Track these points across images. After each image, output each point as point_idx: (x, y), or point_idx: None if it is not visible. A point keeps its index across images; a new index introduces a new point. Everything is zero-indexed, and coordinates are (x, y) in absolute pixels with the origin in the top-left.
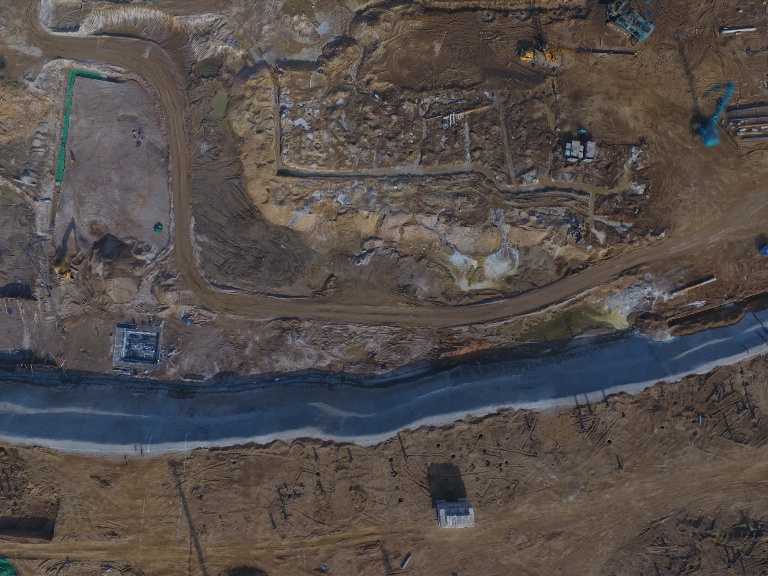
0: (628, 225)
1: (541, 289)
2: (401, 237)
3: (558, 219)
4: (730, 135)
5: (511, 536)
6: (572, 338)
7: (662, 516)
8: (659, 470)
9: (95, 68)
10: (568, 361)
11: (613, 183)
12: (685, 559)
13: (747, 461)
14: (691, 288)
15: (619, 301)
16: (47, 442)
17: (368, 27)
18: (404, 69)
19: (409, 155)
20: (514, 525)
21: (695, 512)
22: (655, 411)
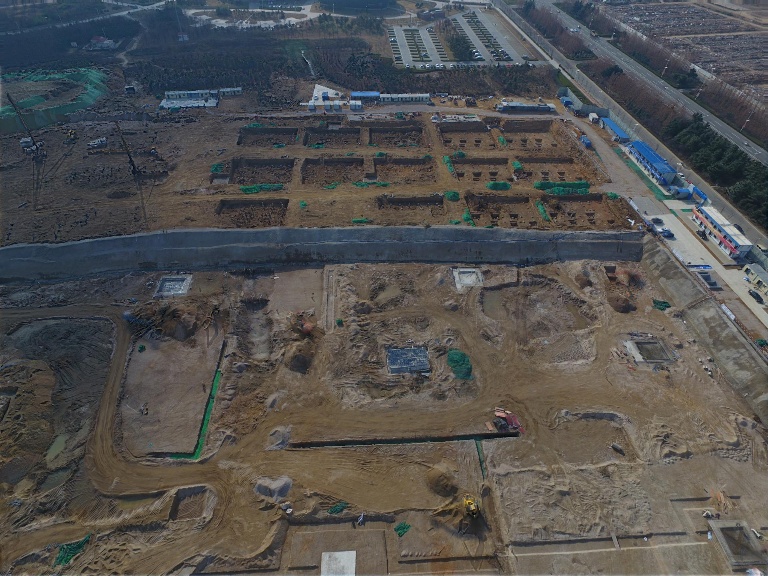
0: None
1: None
2: None
3: None
4: None
5: None
6: None
7: None
8: None
9: None
10: None
11: None
12: None
13: None
14: None
15: None
16: (218, 230)
17: None
18: None
19: None
20: None
21: None
22: None
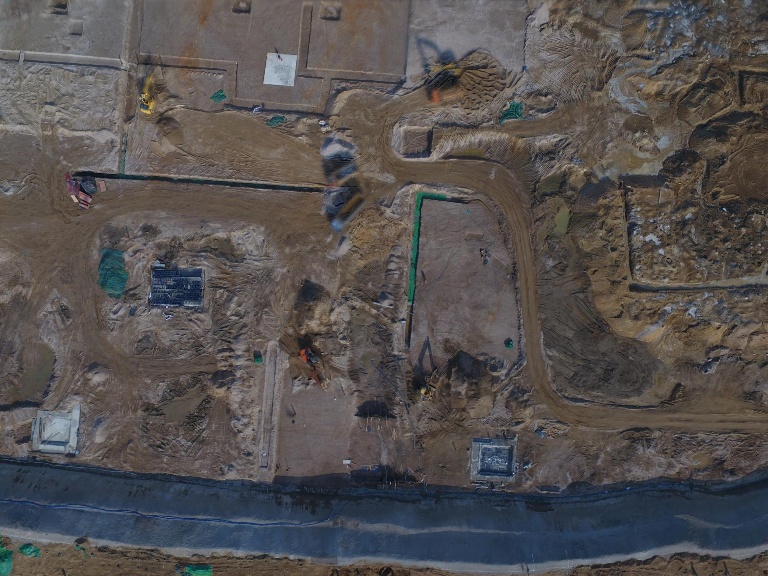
0: None
1: None
2: (747, 345)
3: None
4: None
5: None
6: None
7: None
8: None
9: (444, 191)
10: None
11: None
12: None
13: None
14: None
15: None
16: (439, 564)
17: (717, 143)
18: (750, 181)
19: (758, 266)
20: None
21: None
22: None
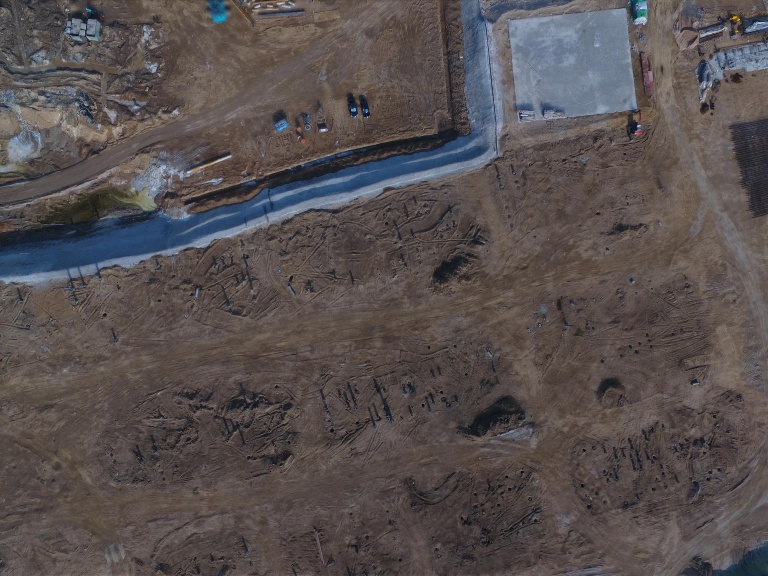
0: (142, 104)
1: (63, 171)
2: None
3: (68, 99)
4: (245, 12)
5: (3, 408)
6: (97, 220)
7: (158, 388)
8: (156, 343)
9: None
10: (84, 240)
11: (126, 62)
12: (181, 431)
13: (247, 334)
14: (206, 166)
15: (144, 182)
16: None
17: None
18: None
19: None
20: (7, 397)
21: (193, 385)
22: (150, 284)
